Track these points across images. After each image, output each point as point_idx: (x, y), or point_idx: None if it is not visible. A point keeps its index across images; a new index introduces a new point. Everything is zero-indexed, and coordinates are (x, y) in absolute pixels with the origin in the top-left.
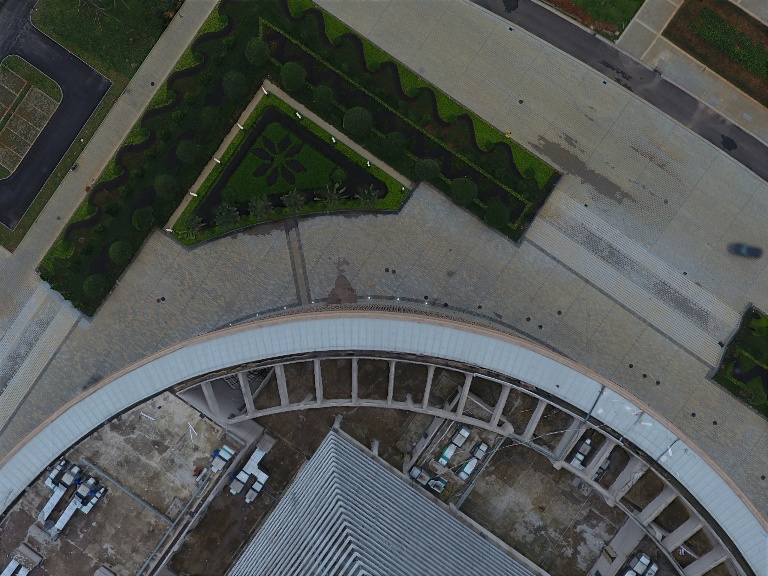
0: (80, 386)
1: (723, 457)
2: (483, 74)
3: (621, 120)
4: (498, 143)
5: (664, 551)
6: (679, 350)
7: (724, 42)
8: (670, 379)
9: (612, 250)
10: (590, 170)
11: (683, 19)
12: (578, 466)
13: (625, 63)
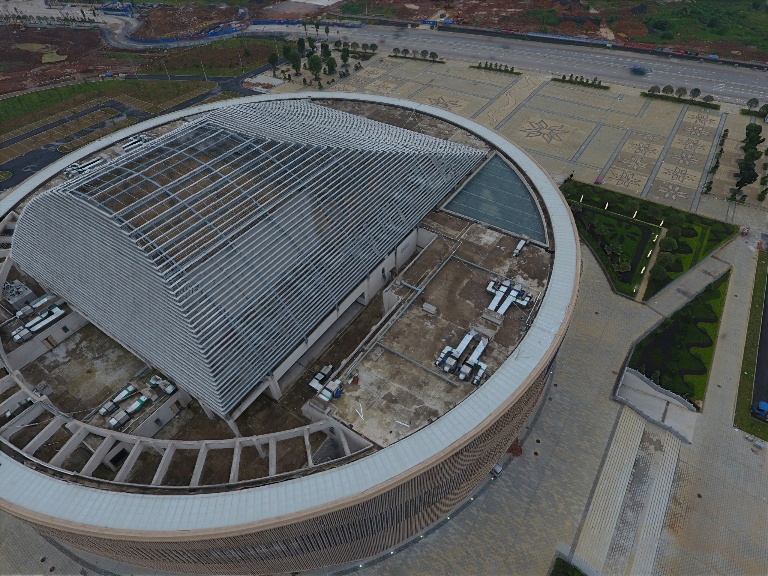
0: (549, 475)
1: None
2: None
3: None
4: None
5: None
6: None
7: None
8: None
9: None
10: None
11: None
12: None
13: None
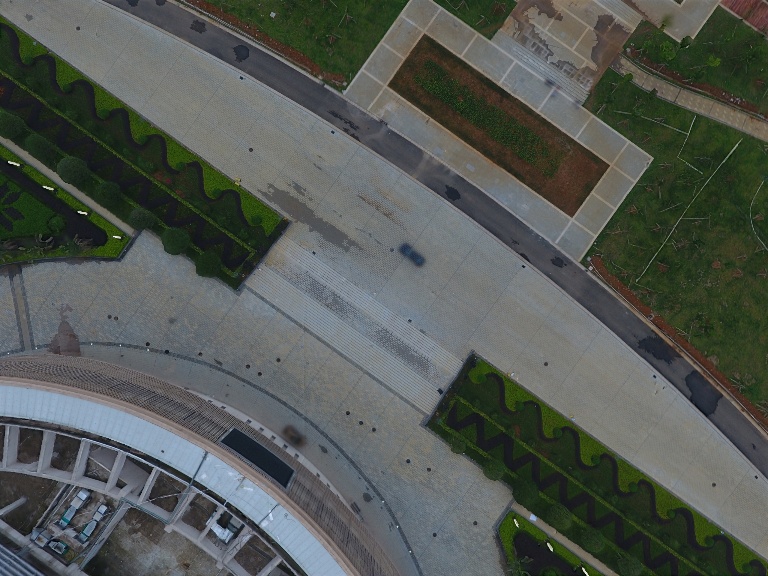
0: None
1: (437, 503)
2: (214, 122)
3: (349, 169)
4: (227, 191)
5: None
6: (395, 398)
7: (446, 95)
8: (386, 426)
9: (336, 298)
10: (318, 218)
11: (409, 71)
12: (214, 525)
13: (353, 113)
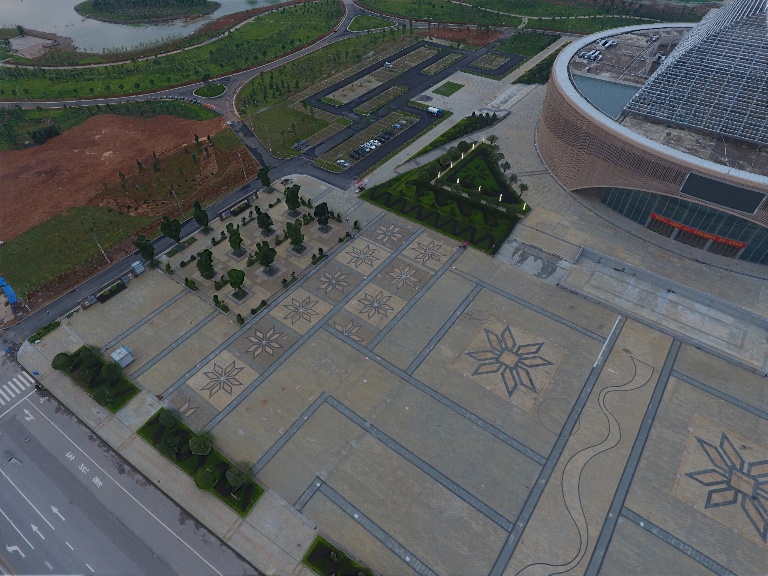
0: None
1: None
2: None
3: None
4: None
5: None
6: None
7: None
8: None
9: None
10: None
11: None
12: None
13: None
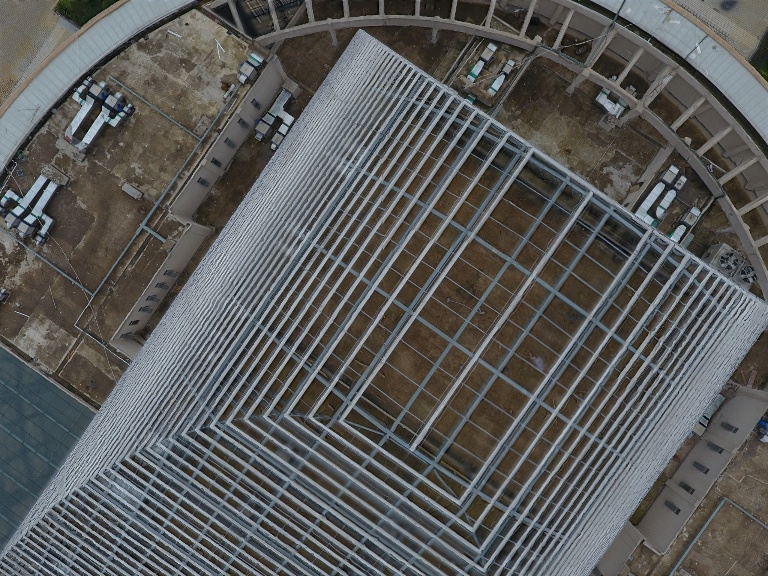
0: None
1: None
2: None
3: None
4: None
5: (693, 155)
6: None
7: None
8: None
9: None
10: None
11: None
12: (604, 100)
13: None
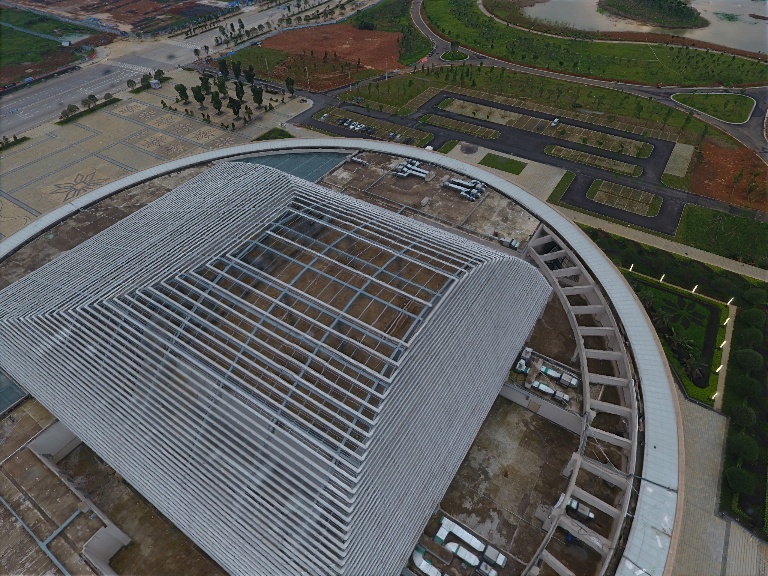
0: None
1: None
2: None
3: None
4: None
5: None
6: None
7: None
8: None
9: None
10: None
11: None
12: None
13: None
